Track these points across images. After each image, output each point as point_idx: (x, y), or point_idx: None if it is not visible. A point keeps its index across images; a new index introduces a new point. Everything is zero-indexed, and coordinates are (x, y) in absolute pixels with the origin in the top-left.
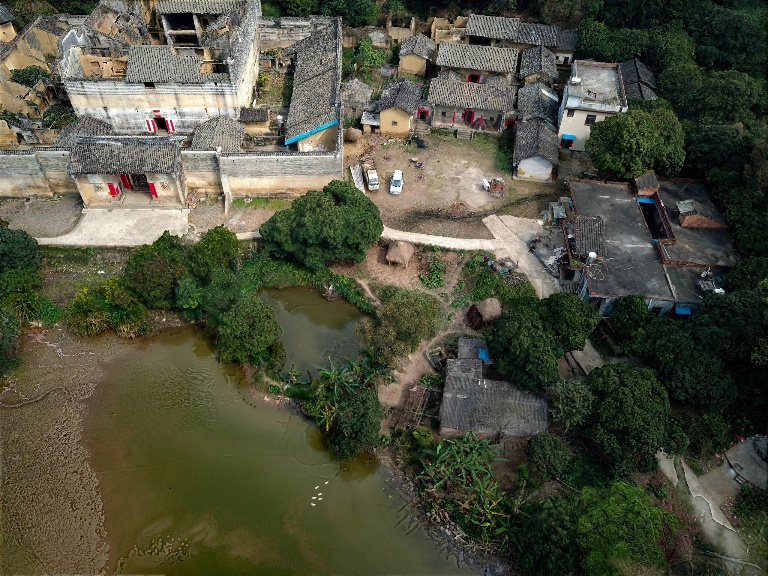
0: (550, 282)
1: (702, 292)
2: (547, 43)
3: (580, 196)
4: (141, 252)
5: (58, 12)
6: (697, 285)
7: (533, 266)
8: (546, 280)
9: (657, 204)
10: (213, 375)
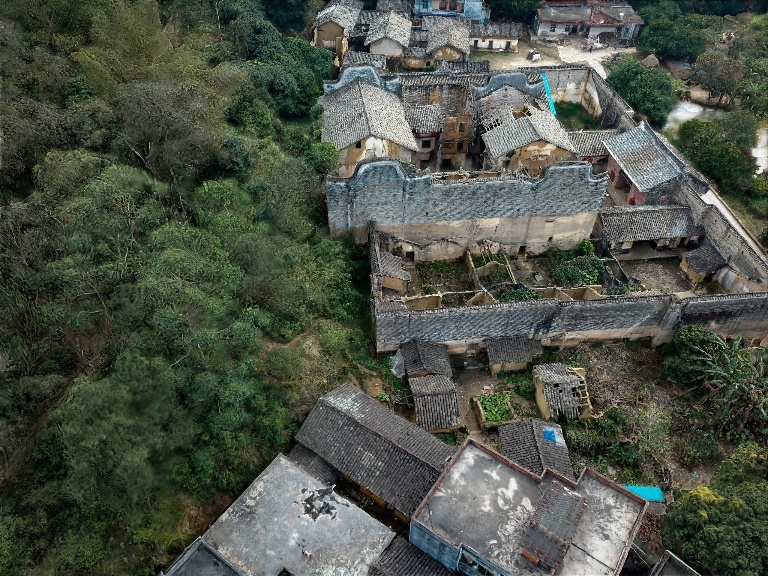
0: (611, 49)
1: (619, 2)
2: (359, 8)
3: (557, 19)
4: (741, 153)
5: (305, 333)
6: (615, 2)
7: (602, 52)
8: (611, 50)
9: (552, 3)
10: (761, 159)
